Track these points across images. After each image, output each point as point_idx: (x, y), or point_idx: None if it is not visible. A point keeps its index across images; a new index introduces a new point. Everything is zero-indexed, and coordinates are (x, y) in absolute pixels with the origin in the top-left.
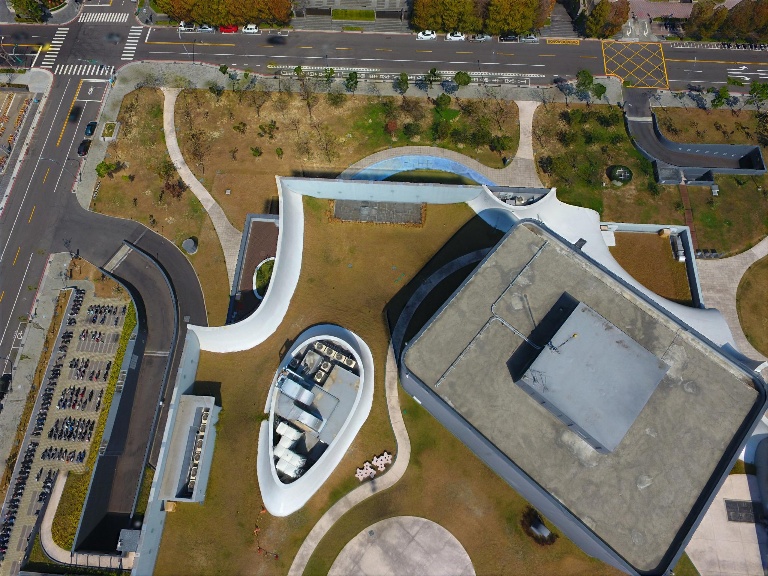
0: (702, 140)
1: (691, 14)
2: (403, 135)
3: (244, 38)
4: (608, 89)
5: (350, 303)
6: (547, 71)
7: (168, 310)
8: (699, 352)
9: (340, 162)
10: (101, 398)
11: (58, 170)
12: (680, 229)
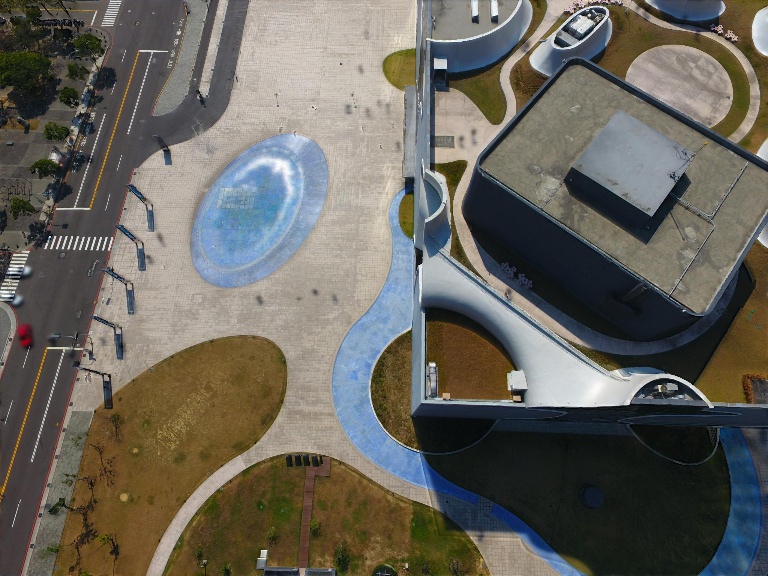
0: None
1: None
2: None
3: None
4: None
5: None
6: None
7: None
8: (525, 195)
9: None
10: None
11: None
12: (430, 401)
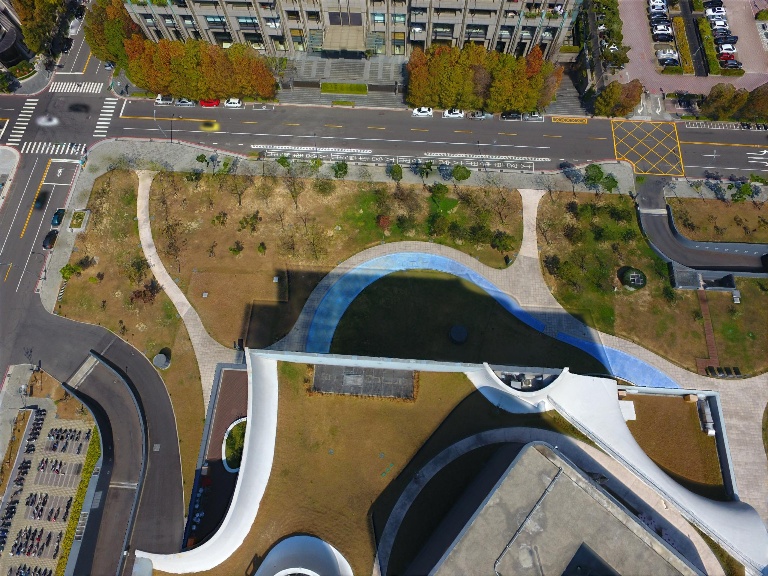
0: (721, 237)
1: (709, 96)
2: (396, 228)
3: (226, 113)
4: (619, 176)
5: (330, 502)
6: (552, 154)
7: (137, 433)
8: None
9: (328, 260)
10: (60, 542)
11: (21, 266)
12: (708, 394)
